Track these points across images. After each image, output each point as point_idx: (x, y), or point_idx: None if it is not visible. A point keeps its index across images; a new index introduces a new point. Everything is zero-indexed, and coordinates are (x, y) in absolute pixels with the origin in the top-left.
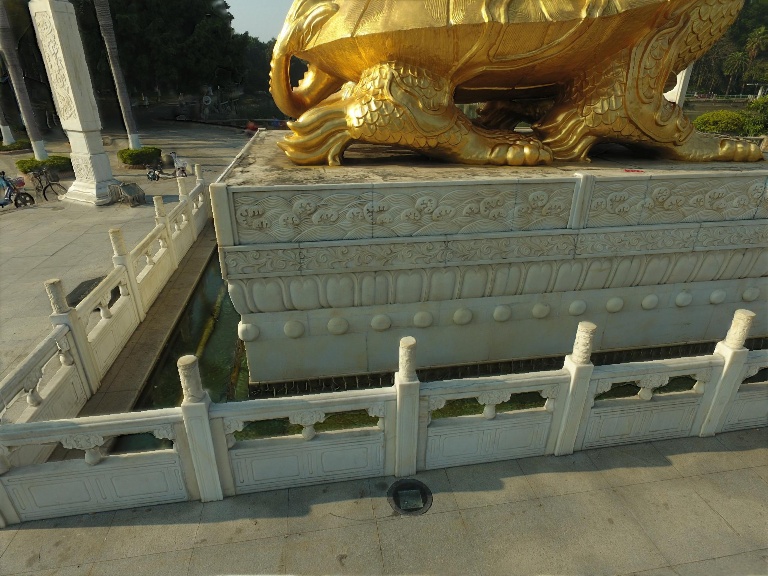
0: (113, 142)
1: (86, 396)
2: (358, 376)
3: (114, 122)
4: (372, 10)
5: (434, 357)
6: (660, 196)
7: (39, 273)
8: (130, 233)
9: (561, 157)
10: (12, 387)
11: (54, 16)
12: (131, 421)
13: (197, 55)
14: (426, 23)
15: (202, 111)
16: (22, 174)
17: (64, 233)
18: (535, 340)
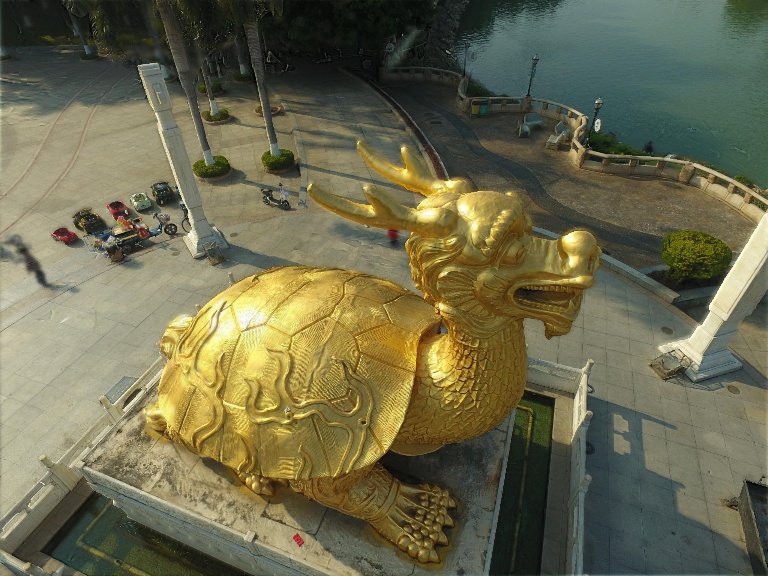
0: (285, 114)
1: (66, 493)
2: (173, 539)
3: (305, 73)
4: (166, 387)
5: (208, 551)
6: (301, 567)
7: (119, 349)
8: (187, 310)
9: (293, 487)
10: (10, 515)
11: (166, 141)
12: (20, 568)
13: (377, 14)
14: (172, 424)
15: (384, 58)
16: (195, 175)
17: (158, 296)
18: (261, 574)
